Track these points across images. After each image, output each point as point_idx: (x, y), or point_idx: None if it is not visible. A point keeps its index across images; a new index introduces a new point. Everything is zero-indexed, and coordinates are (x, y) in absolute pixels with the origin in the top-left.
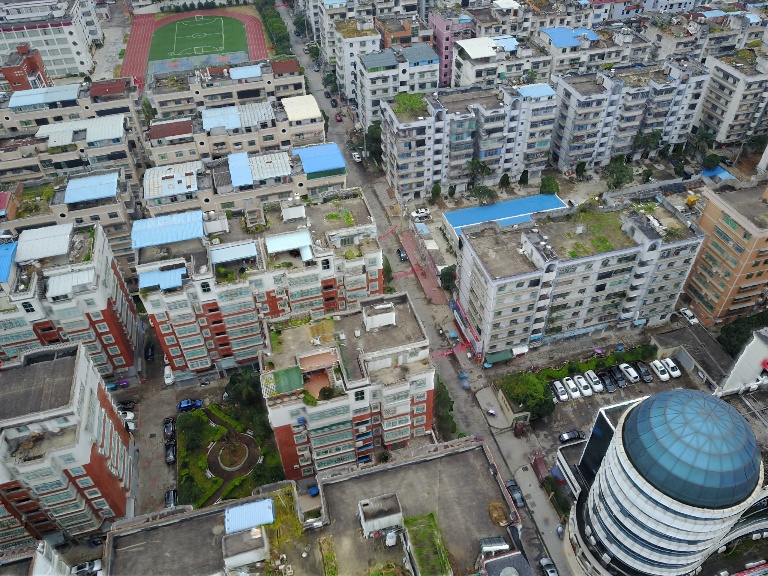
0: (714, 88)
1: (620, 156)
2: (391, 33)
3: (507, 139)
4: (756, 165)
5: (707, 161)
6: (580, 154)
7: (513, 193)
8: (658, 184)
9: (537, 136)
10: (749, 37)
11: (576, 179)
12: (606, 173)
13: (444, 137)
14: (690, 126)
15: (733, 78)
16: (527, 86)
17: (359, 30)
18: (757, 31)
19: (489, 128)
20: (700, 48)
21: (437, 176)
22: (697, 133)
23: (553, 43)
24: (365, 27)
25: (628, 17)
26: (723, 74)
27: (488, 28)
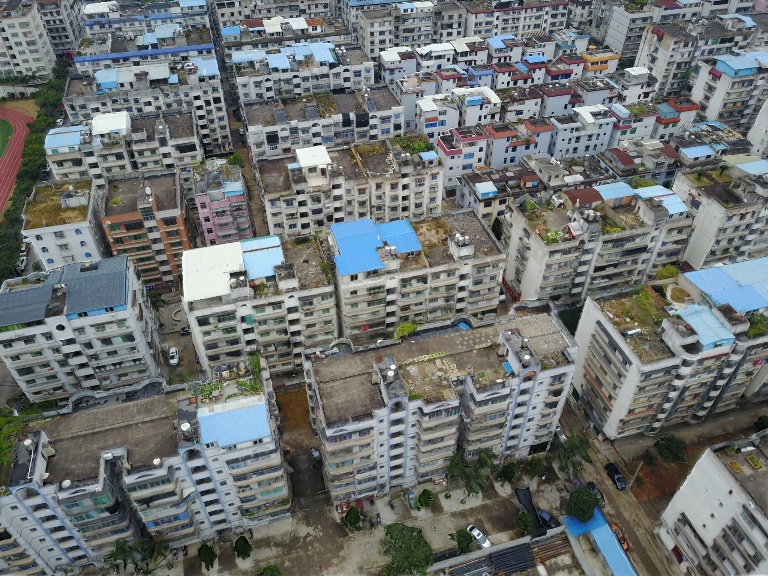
0: (597, 353)
1: (423, 494)
2: (106, 217)
3: (199, 491)
4: (660, 511)
5: (574, 506)
6: (353, 490)
7: (229, 564)
8: (486, 551)
9: (255, 486)
10: (668, 234)
11: (351, 525)
12: (389, 540)
13: (57, 512)
14: (553, 424)
15: (622, 356)
16: (224, 409)
17: (62, 208)
18: (681, 226)
19: (142, 497)
20: (591, 252)
21: (75, 552)
22: (579, 403)
23: (336, 265)
24: (72, 203)
25: (514, 156)
26: (608, 339)
27: (275, 200)
